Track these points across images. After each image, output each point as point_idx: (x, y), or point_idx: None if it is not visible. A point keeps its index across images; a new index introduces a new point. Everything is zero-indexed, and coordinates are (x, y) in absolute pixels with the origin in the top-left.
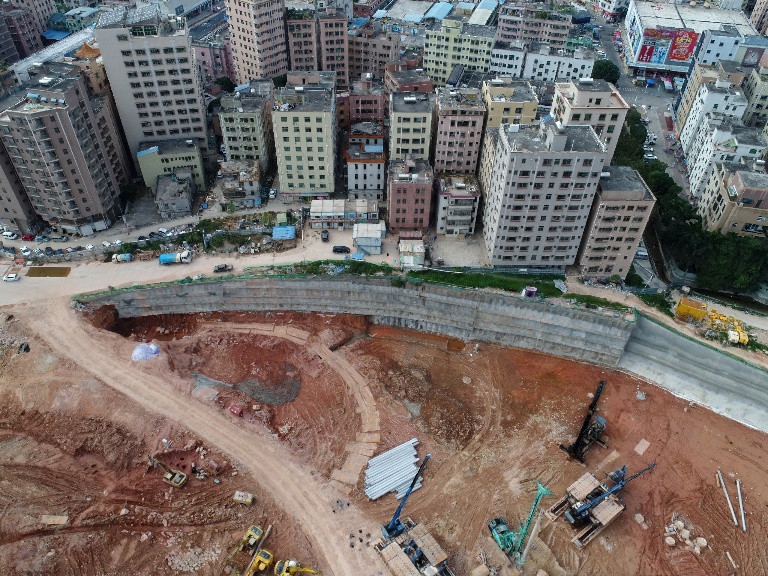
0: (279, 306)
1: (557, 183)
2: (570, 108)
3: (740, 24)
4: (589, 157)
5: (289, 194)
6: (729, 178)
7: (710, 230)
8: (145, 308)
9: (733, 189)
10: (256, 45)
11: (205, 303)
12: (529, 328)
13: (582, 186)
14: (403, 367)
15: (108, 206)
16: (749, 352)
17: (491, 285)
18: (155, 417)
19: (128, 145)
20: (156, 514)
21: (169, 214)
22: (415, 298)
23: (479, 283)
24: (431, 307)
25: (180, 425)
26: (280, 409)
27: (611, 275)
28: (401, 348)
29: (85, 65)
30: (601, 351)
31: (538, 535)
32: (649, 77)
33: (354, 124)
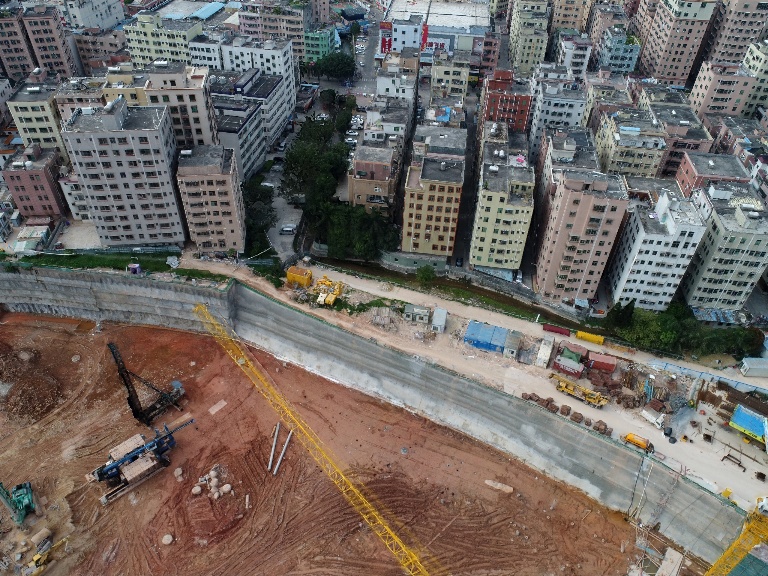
0: None
1: (124, 161)
2: (144, 90)
3: (480, 16)
4: (142, 135)
5: None
6: None
7: None
8: None
9: None
10: None
11: None
12: (146, 304)
13: (151, 163)
14: (13, 350)
15: None
16: (333, 312)
17: (100, 265)
18: None
19: None
20: None
21: None
22: (35, 283)
23: (89, 264)
24: (53, 291)
25: None
26: None
27: (228, 249)
28: (24, 333)
29: None
30: (214, 322)
31: (66, 496)
32: None
33: None
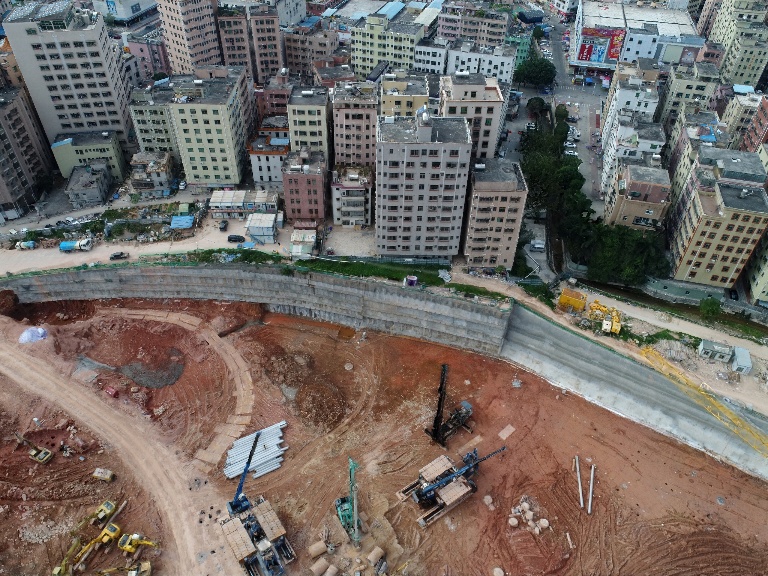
0: (176, 293)
1: (428, 173)
2: (445, 101)
3: (682, 24)
4: (455, 148)
5: (196, 185)
6: (623, 172)
7: (606, 223)
8: (44, 294)
9: (623, 183)
10: (186, 41)
11: (103, 290)
12: (414, 317)
13: (453, 177)
14: (288, 353)
15: (18, 195)
16: (620, 341)
17: (375, 274)
18: (31, 397)
19: (47, 137)
20: (16, 489)
21: (81, 204)
22: (305, 286)
23: (364, 272)
24: (321, 295)
25: (55, 405)
26: (158, 392)
27: (496, 266)
28: (291, 335)
29: (2, 58)
30: (483, 340)
31: (384, 514)
32: (590, 76)
33: (267, 118)
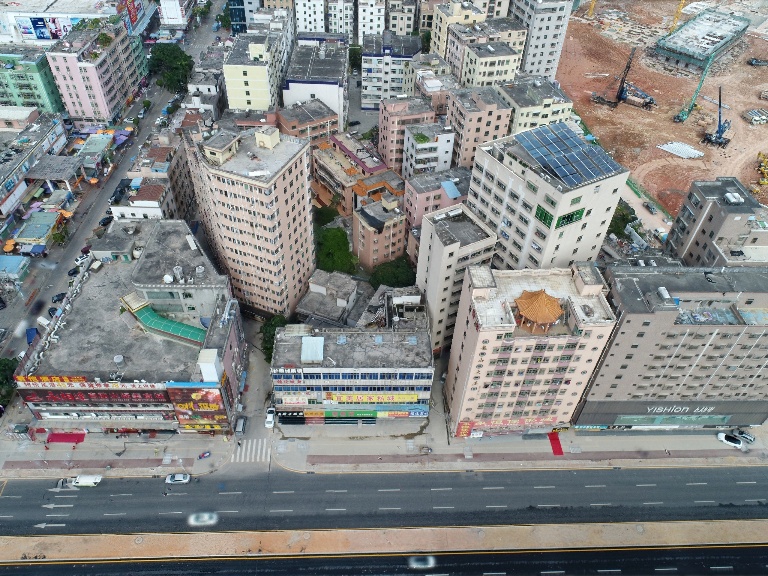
0: None
1: None
2: None
3: None
4: None
5: None
6: (423, 6)
7: None
8: None
9: None
10: (308, 207)
11: None
12: None
13: None
14: None
15: None
16: None
17: None
18: None
19: None
20: None
21: None
22: None
23: None
24: None
25: None
26: None
27: None
28: None
29: None
30: None
31: None
32: None
33: None
